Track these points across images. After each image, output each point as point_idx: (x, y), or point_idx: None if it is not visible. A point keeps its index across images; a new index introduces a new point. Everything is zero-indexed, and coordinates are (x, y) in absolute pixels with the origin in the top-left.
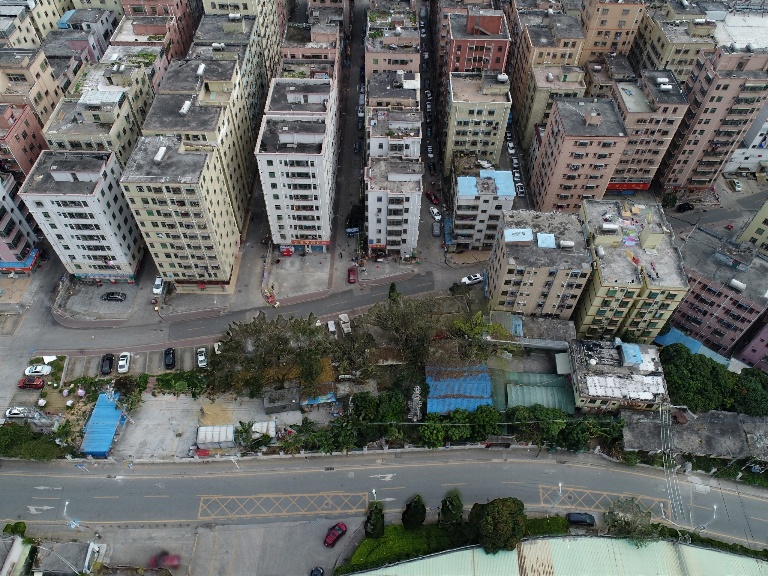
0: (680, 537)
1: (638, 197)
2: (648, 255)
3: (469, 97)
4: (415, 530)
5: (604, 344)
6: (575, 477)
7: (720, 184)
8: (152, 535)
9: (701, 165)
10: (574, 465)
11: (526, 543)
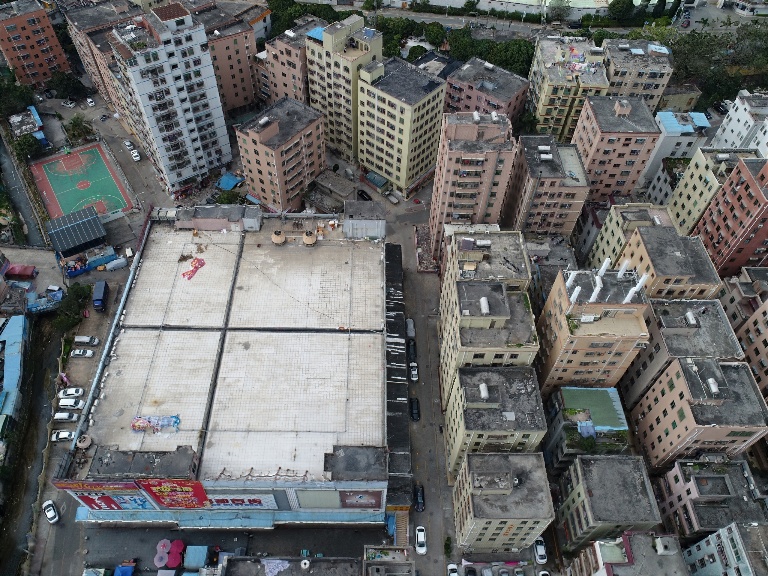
0: None
1: None
2: None
3: None
4: (651, 22)
5: None
6: None
7: (403, 253)
8: None
9: None
10: None
11: (606, 6)
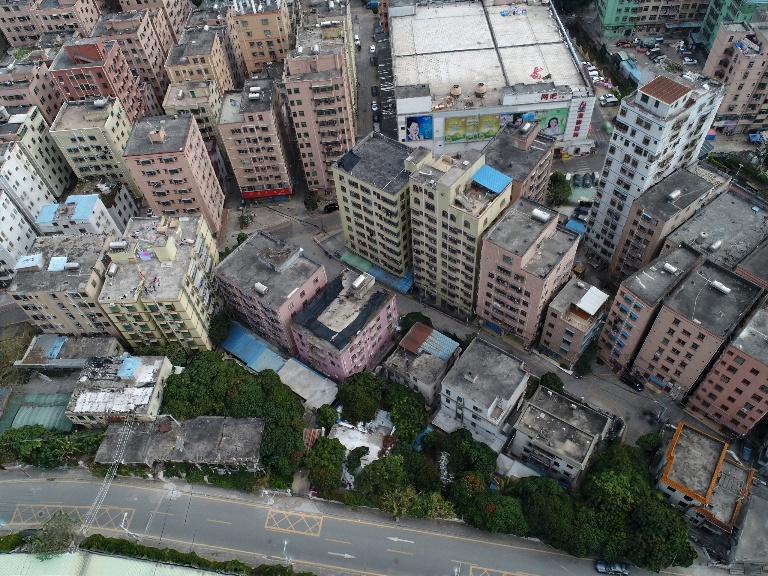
0: (68, 548)
1: (291, 202)
2: (162, 268)
3: (72, 125)
4: None
5: (115, 359)
6: (56, 493)
7: None
8: None
9: (328, 166)
10: (61, 481)
11: None
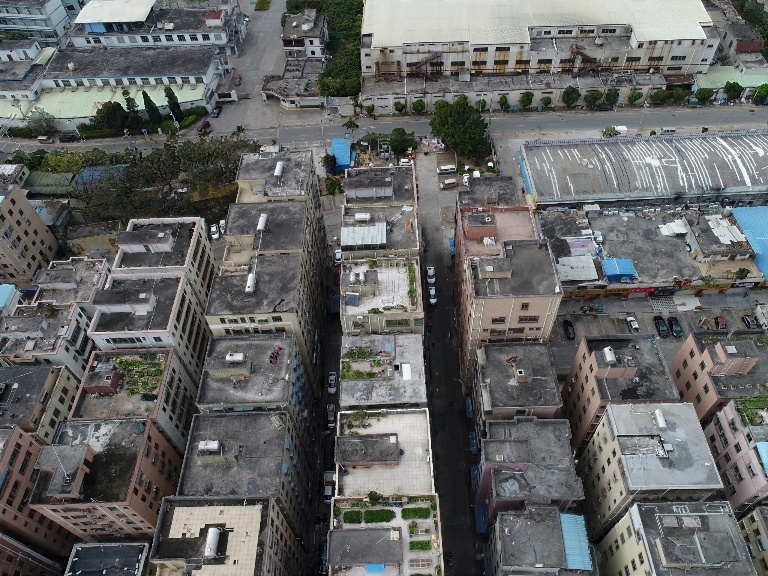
0: (20, 106)
1: None
2: None
3: None
4: None
5: None
6: None
7: None
8: (303, 123)
9: None
10: None
11: None
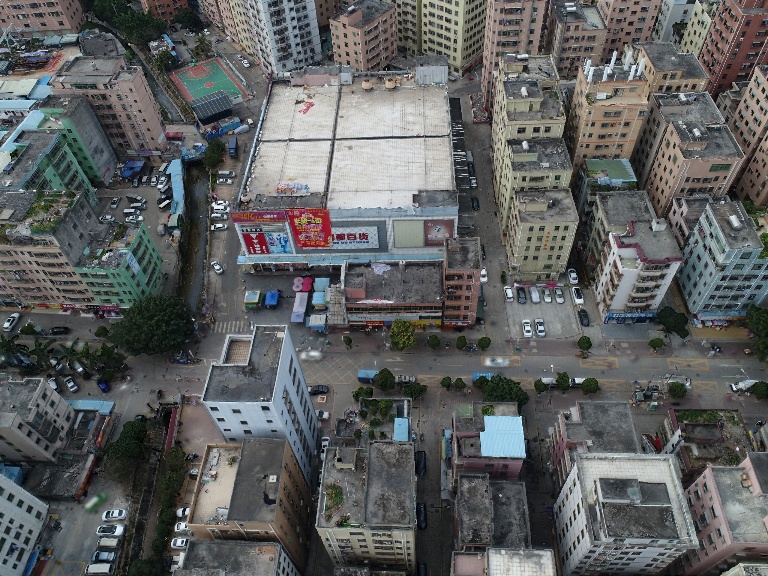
0: None
1: None
2: None
3: None
4: None
5: None
6: None
7: None
8: None
9: None
10: None
11: None
